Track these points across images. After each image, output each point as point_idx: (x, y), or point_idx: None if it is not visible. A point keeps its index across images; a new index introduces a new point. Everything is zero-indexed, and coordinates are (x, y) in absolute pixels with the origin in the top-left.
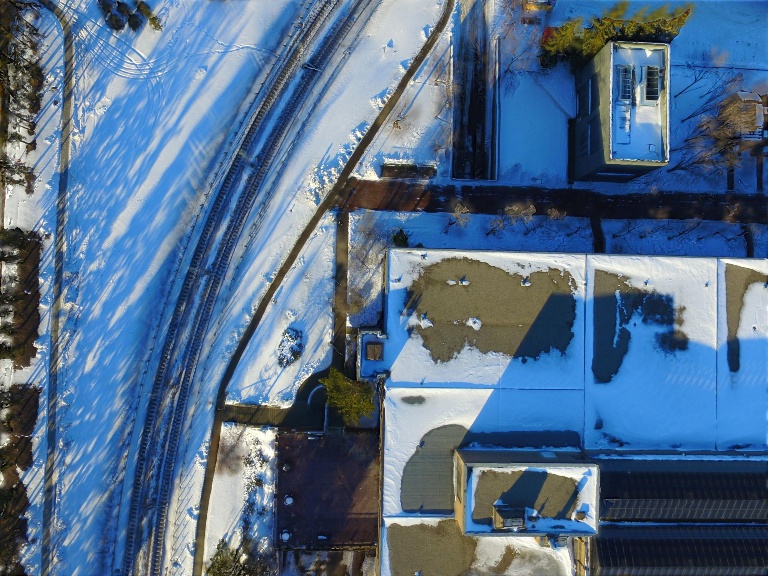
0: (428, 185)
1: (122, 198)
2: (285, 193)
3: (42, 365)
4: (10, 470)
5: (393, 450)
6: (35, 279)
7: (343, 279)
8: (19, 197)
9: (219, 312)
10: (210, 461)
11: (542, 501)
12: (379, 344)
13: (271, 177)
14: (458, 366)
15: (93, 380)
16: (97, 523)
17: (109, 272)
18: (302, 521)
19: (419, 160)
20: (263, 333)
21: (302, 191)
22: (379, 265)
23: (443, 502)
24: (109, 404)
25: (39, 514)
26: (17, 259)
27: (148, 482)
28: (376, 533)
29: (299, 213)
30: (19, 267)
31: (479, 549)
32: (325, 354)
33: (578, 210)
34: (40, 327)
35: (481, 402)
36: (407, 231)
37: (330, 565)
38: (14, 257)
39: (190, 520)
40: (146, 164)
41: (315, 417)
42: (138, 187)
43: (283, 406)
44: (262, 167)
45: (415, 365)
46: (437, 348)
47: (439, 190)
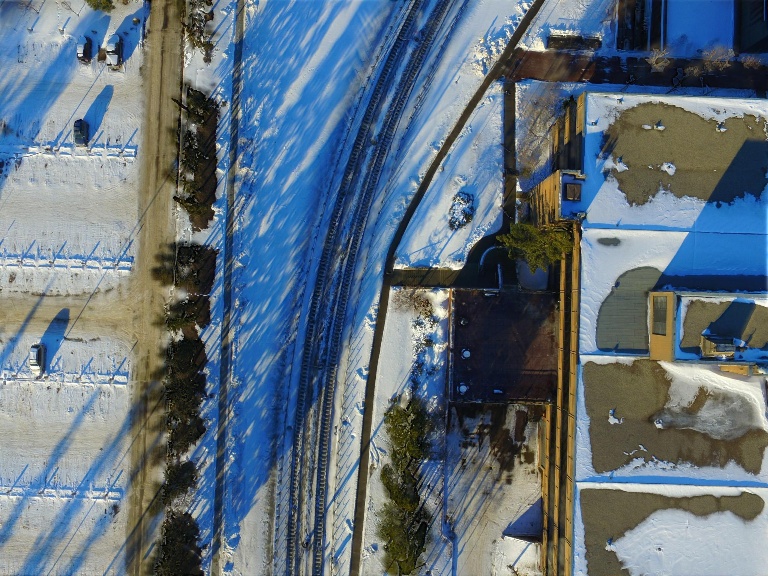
0: (593, 57)
1: (295, 67)
2: (450, 66)
3: (219, 227)
4: (190, 327)
5: (589, 289)
6: (212, 144)
7: (512, 146)
8: (197, 65)
9: (385, 181)
10: (379, 324)
11: (750, 332)
12: (578, 184)
13: (435, 51)
14: (653, 209)
15: (267, 243)
16: (271, 381)
17: (282, 139)
18: (477, 376)
19: (585, 31)
20: (431, 200)
21: (467, 63)
22: (547, 133)
23: (638, 342)
24: (282, 266)
25: (216, 370)
26: (203, 119)
27: (318, 344)
28: (550, 390)
29: (465, 84)
30: (198, 132)
31: (673, 390)
32: (496, 217)
33: (743, 83)
34: (217, 191)
35: (676, 245)
36: (574, 100)
37: (493, 429)
38: (202, 116)
39: (359, 380)
40: (317, 35)
41: (485, 279)
42: (310, 57)
43: (455, 267)
44: (426, 42)
45: (611, 207)
46: (632, 191)
47: (604, 62)
